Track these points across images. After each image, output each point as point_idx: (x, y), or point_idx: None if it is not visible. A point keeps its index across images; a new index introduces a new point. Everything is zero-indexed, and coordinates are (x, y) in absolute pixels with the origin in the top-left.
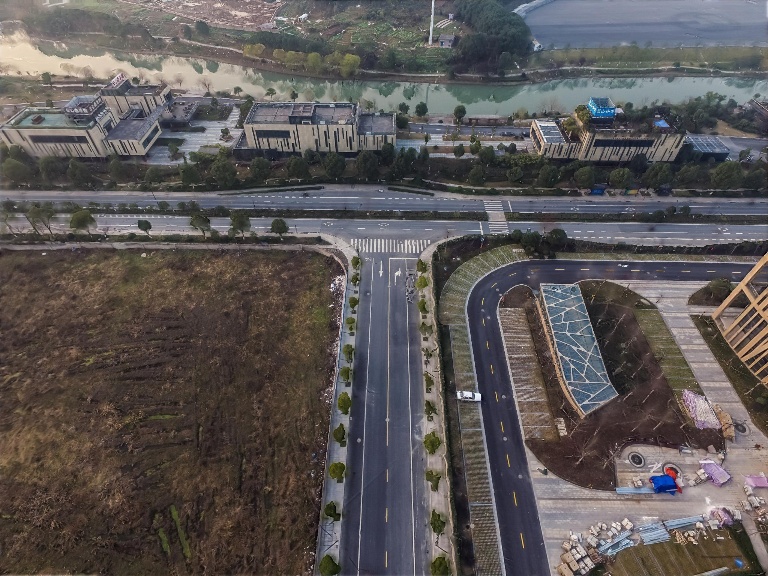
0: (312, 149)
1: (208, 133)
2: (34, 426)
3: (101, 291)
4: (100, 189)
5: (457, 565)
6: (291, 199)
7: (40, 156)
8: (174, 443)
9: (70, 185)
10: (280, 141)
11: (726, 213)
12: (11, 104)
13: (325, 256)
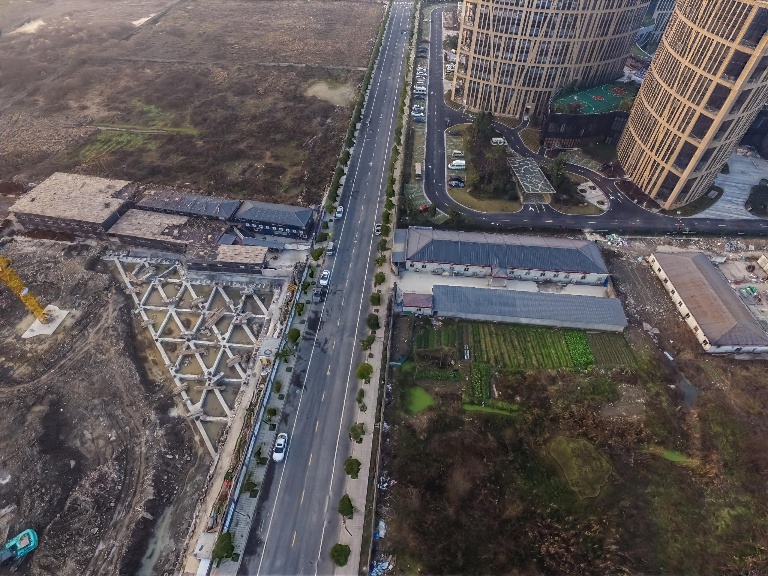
0: None
1: None
2: None
3: None
4: None
5: None
6: None
7: None
8: (334, 23)
9: None
10: None
11: None
12: None
13: None
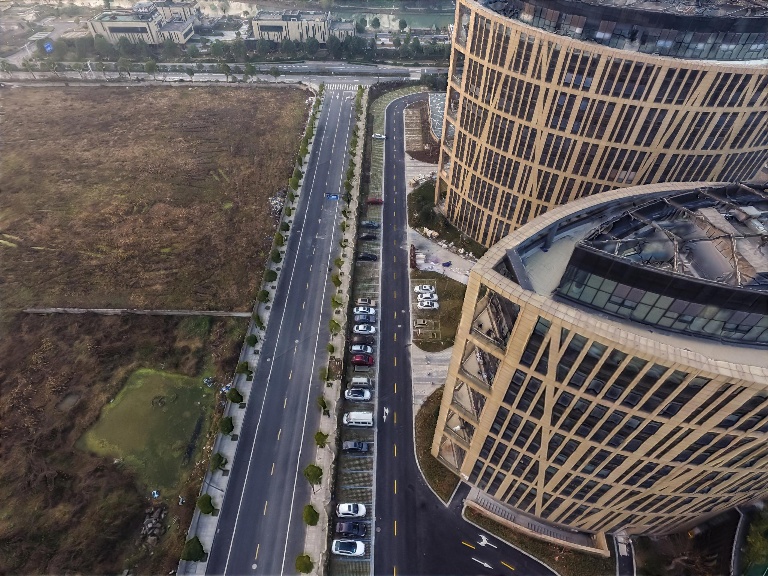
0: (298, 41)
1: (226, 37)
2: (141, 145)
3: (167, 102)
4: (156, 61)
5: (360, 180)
6: (283, 67)
7: (114, 43)
8: (217, 151)
9: (136, 59)
10: (276, 34)
11: None
12: (82, 21)
13: (303, 90)
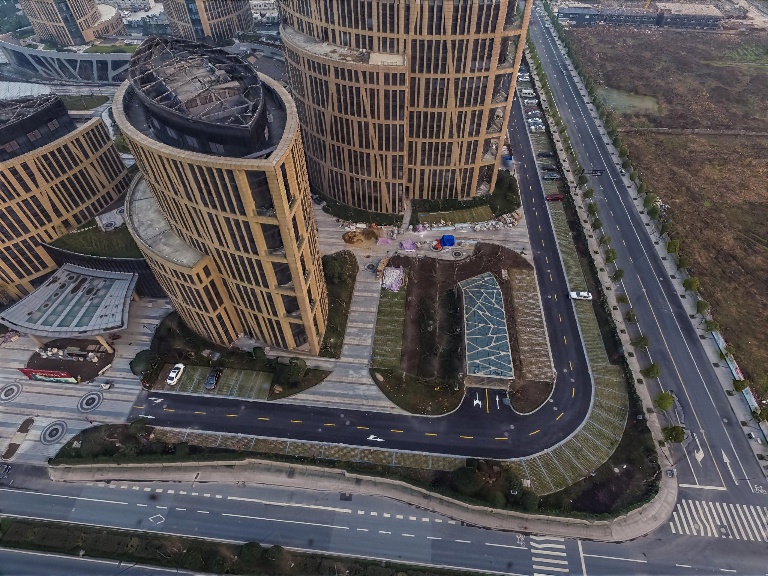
0: None
1: None
2: None
3: None
4: None
5: None
6: None
7: None
8: None
9: None
10: None
11: (109, 567)
12: None
13: None
